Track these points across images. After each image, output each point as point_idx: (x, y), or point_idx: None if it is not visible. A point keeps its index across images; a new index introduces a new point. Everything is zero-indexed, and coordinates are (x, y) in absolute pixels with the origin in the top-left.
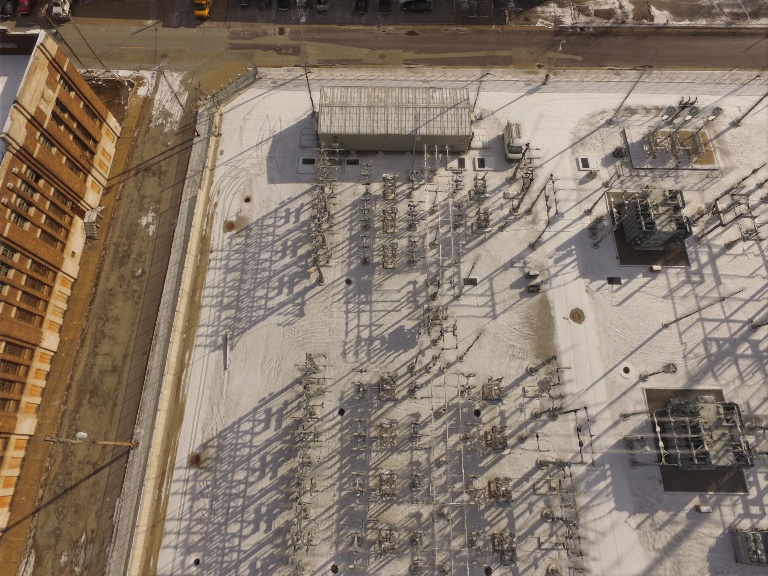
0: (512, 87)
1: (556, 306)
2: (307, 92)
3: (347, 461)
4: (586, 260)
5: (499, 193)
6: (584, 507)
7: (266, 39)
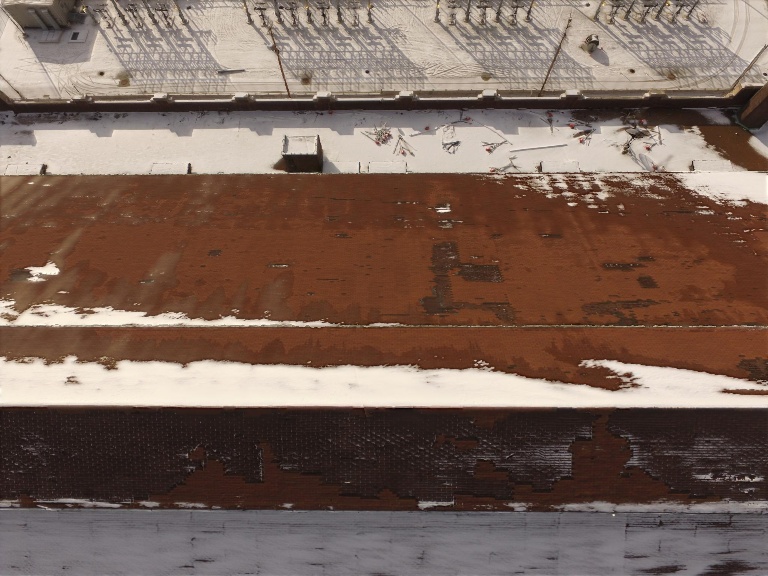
0: None
1: None
2: None
3: (312, 3)
4: None
5: None
6: None
7: None
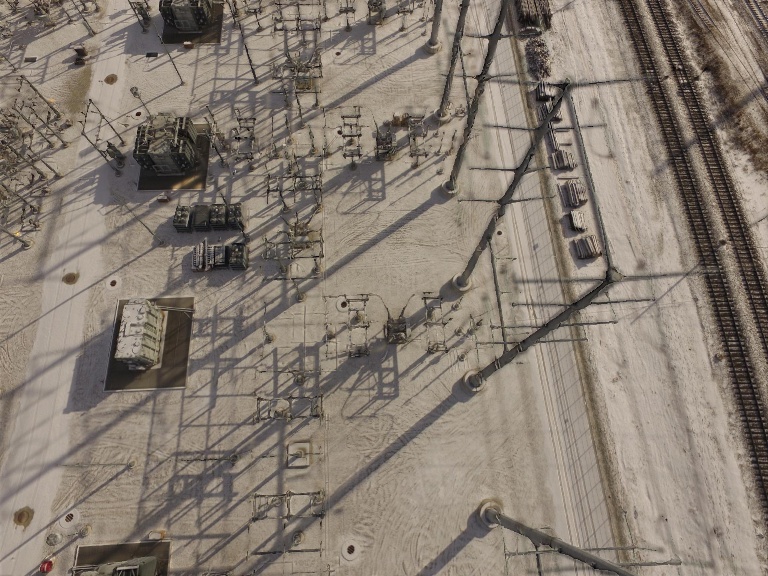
0: None
1: (96, 73)
2: None
3: None
4: (134, 42)
5: None
6: (68, 203)
7: None
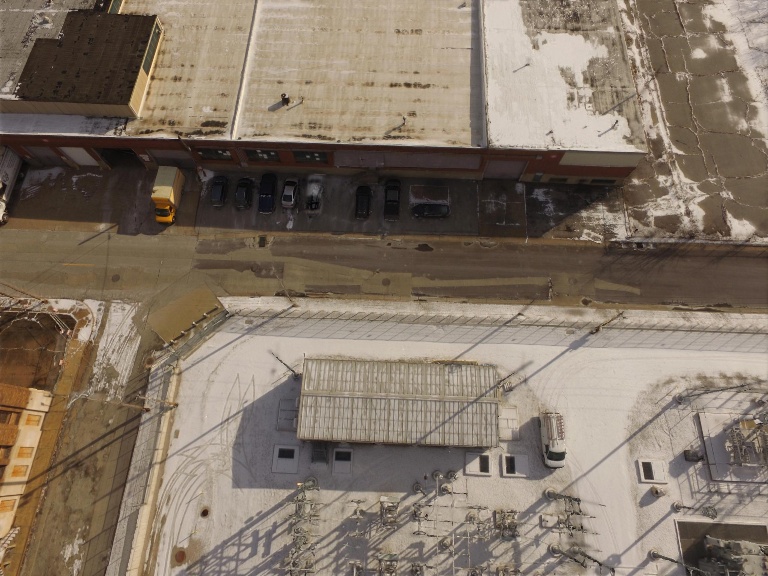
0: (550, 337)
1: None
2: (290, 339)
3: None
4: None
5: (534, 517)
6: None
7: (243, 253)
